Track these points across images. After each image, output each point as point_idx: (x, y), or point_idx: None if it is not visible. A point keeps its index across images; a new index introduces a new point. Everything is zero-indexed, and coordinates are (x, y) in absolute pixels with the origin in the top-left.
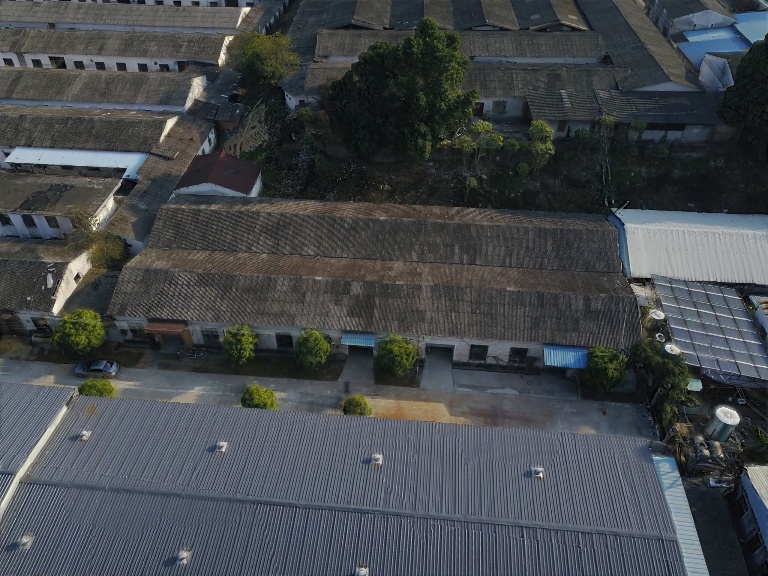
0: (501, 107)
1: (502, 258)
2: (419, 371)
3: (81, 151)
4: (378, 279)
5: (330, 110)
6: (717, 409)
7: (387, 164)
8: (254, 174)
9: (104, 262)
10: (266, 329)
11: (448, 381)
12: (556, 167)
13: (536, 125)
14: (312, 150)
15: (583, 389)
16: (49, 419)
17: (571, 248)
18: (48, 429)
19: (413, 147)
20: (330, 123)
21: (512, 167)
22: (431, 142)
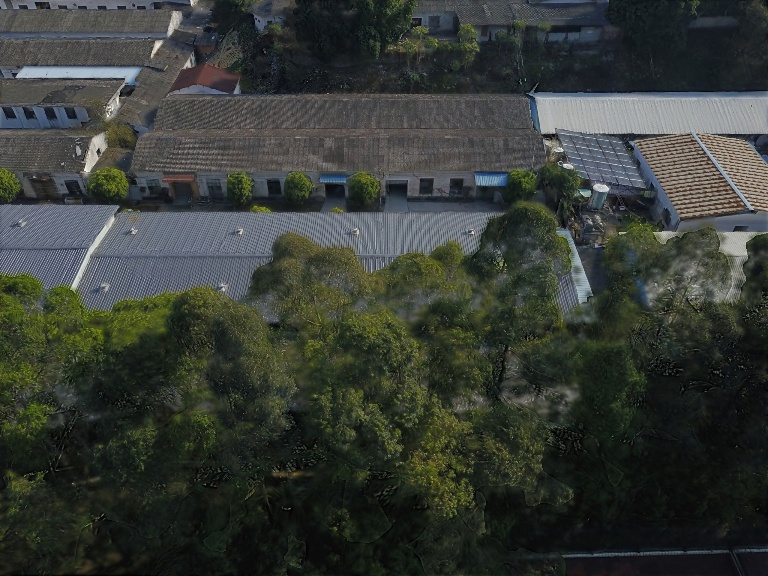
0: (436, 22)
1: (441, 123)
2: (382, 204)
3: (82, 67)
4: (345, 136)
5: (294, 27)
6: (594, 185)
7: (345, 68)
8: (234, 80)
9: (118, 143)
10: (260, 176)
11: (404, 209)
12: (482, 65)
13: (463, 27)
14: (281, 61)
15: (507, 209)
16: (104, 221)
17: (494, 113)
18: (105, 226)
19: (366, 47)
20: (296, 33)
21: (447, 66)
22: (380, 43)
